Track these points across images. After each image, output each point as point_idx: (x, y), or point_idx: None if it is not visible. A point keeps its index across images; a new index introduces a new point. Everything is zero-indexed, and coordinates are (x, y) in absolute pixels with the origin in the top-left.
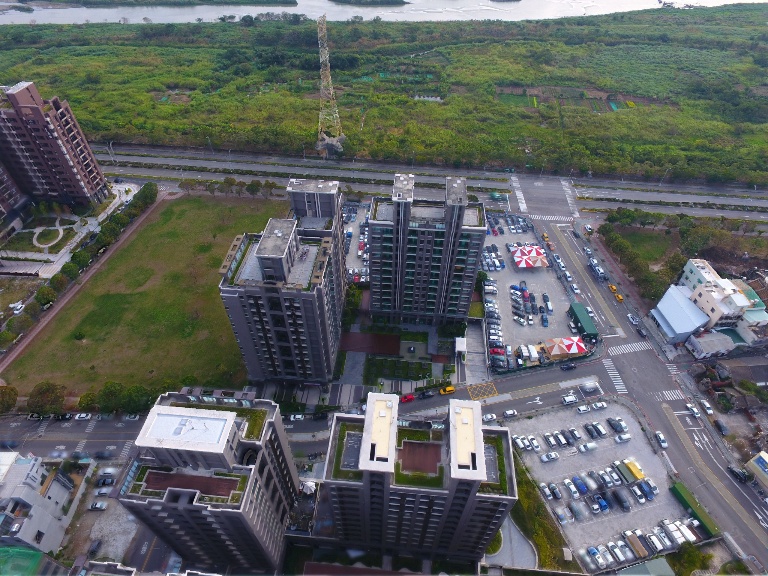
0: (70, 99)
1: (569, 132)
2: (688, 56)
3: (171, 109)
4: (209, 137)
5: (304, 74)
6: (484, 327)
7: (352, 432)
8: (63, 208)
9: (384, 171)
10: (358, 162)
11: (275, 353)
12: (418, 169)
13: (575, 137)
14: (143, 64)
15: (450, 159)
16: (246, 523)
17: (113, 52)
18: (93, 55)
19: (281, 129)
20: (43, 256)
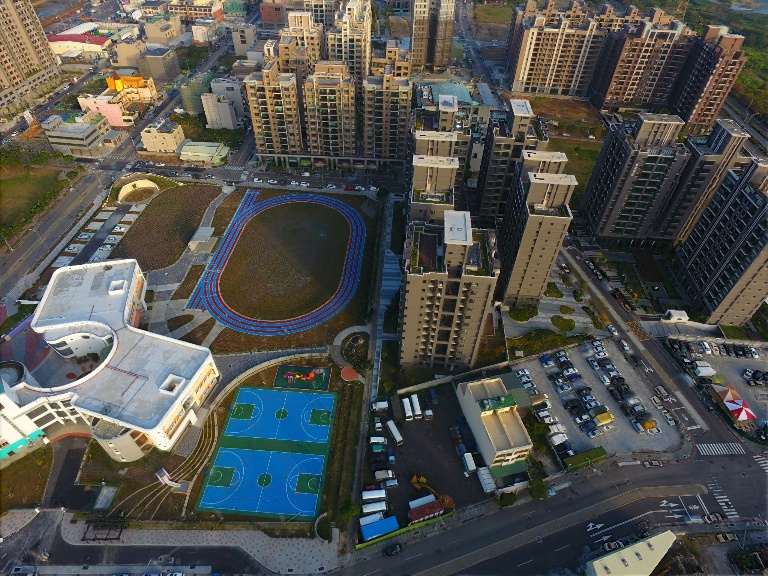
0: None
1: None
2: None
3: None
4: None
5: None
6: None
7: None
8: None
9: None
10: None
11: None
12: None
13: None
14: None
15: None
16: (492, 150)
17: None
18: None
19: None
20: None
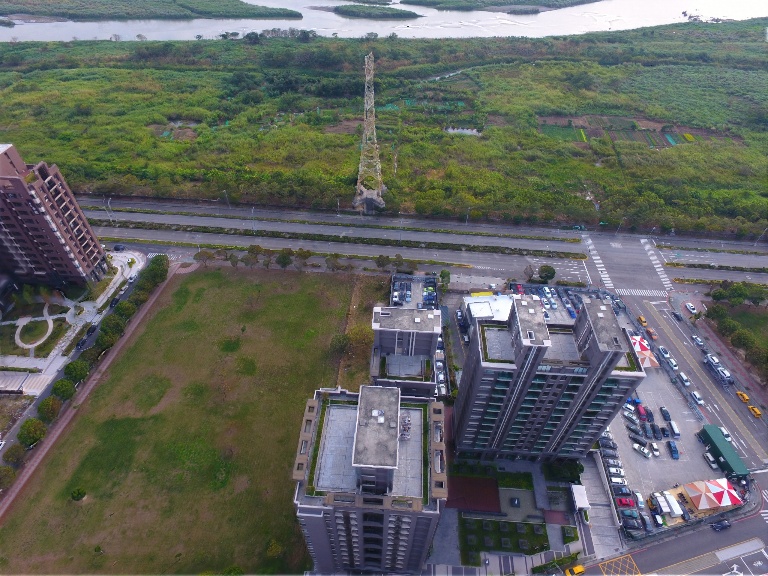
0: (57, 136)
1: (630, 173)
2: (735, 78)
3: (175, 148)
4: (224, 187)
5: (322, 102)
6: (602, 464)
7: None
8: (53, 294)
9: (434, 230)
10: (401, 218)
11: (357, 551)
12: (472, 226)
13: (639, 180)
14: (139, 90)
15: (510, 215)
16: None
17: (105, 76)
18: (82, 80)
19: (308, 177)
20: (28, 361)
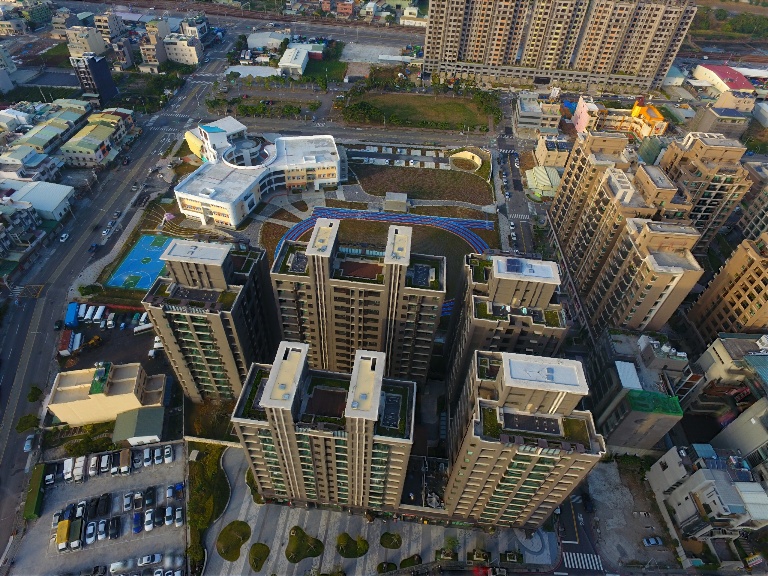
0: None
1: None
2: None
3: None
4: None
5: None
6: None
7: (393, 427)
8: None
9: None
10: None
11: None
12: None
13: None
14: None
15: None
16: None
17: None
18: None
19: None
20: None
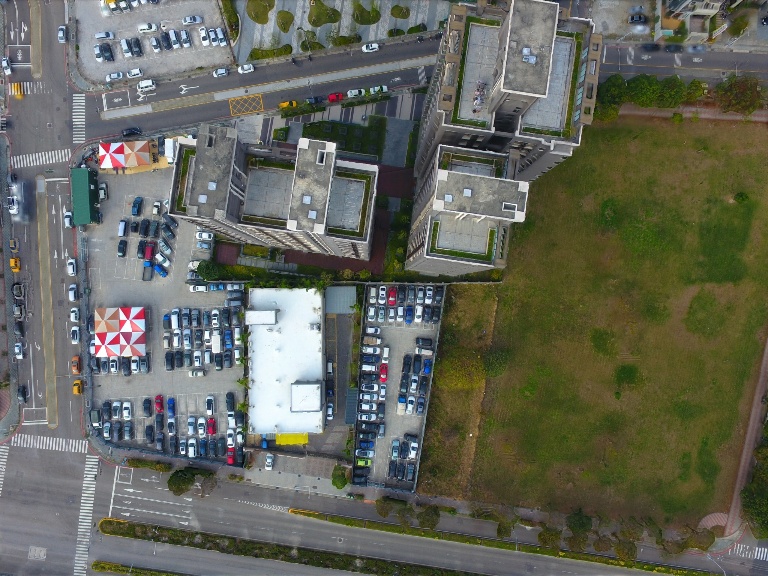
0: None
1: None
2: None
3: None
4: None
5: None
6: None
7: None
8: None
9: None
10: None
11: None
12: None
13: None
14: None
15: None
16: None
17: None
18: None
19: None
20: None
